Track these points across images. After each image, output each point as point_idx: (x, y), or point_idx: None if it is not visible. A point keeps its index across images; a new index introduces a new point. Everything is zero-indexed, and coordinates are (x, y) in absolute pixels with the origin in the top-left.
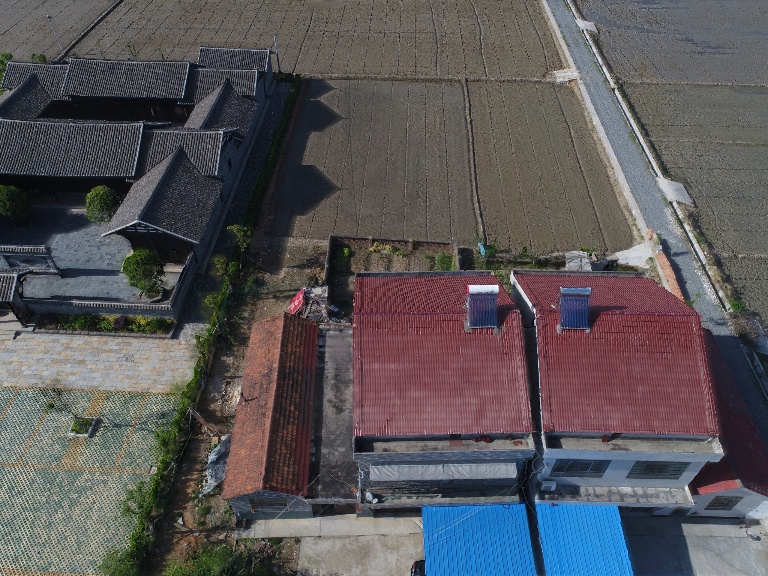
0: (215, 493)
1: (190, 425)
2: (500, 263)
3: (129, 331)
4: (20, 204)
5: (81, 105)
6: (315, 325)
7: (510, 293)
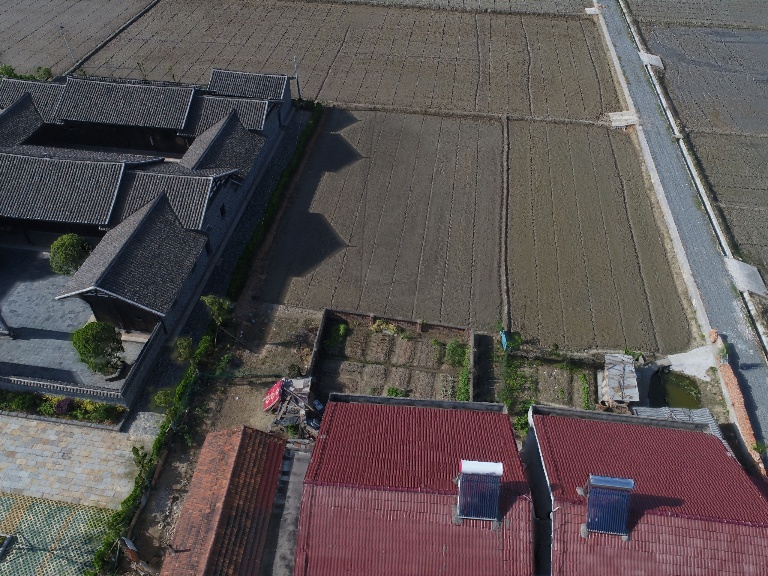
0: None
1: (117, 559)
2: (524, 359)
3: (73, 418)
4: None
5: (76, 129)
6: (281, 443)
7: None
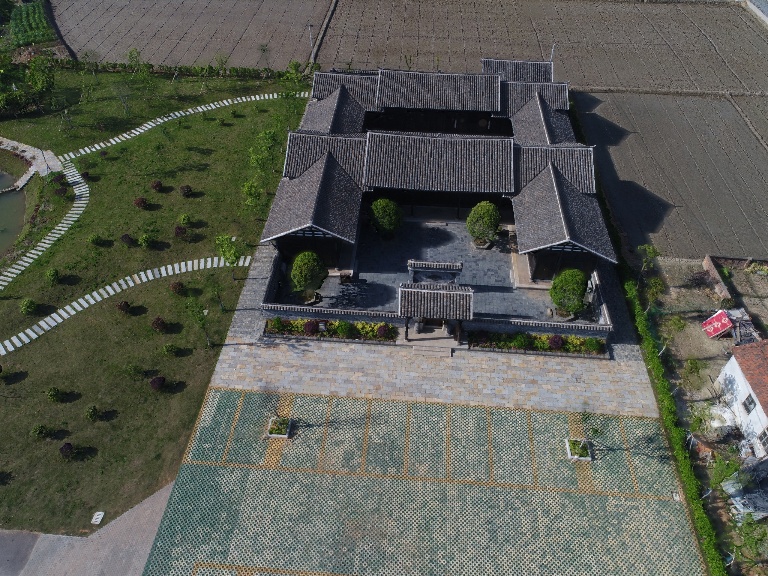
0: (759, 523)
1: (690, 451)
2: None
3: (565, 351)
4: (401, 218)
5: (385, 116)
6: None
7: None
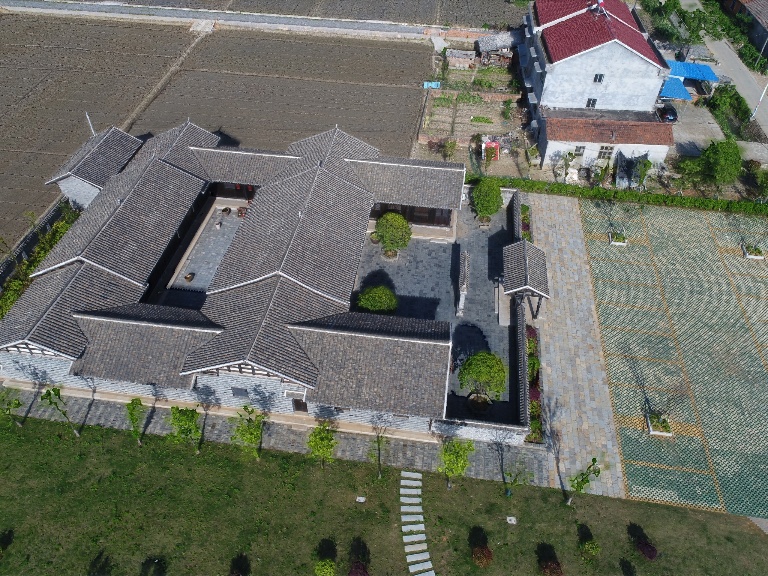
0: None
1: None
2: None
3: None
4: None
5: None
6: None
7: None
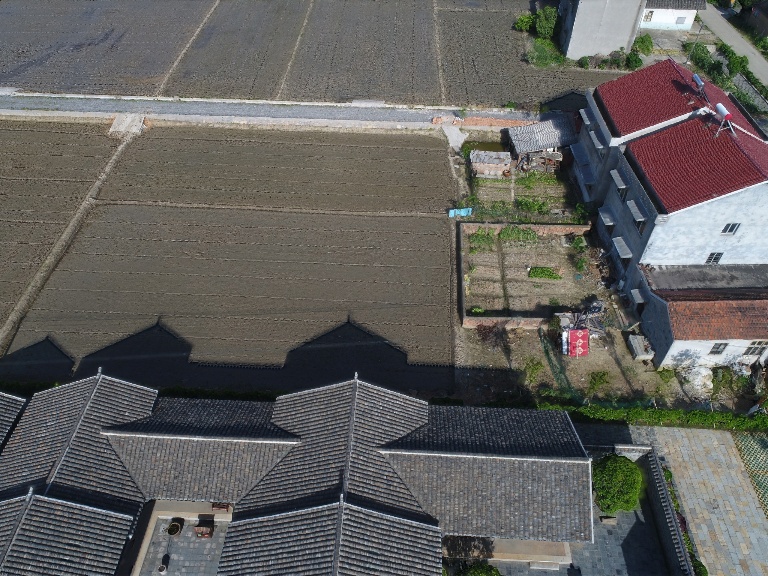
0: None
1: None
2: None
3: None
4: None
5: None
6: None
7: (522, 200)
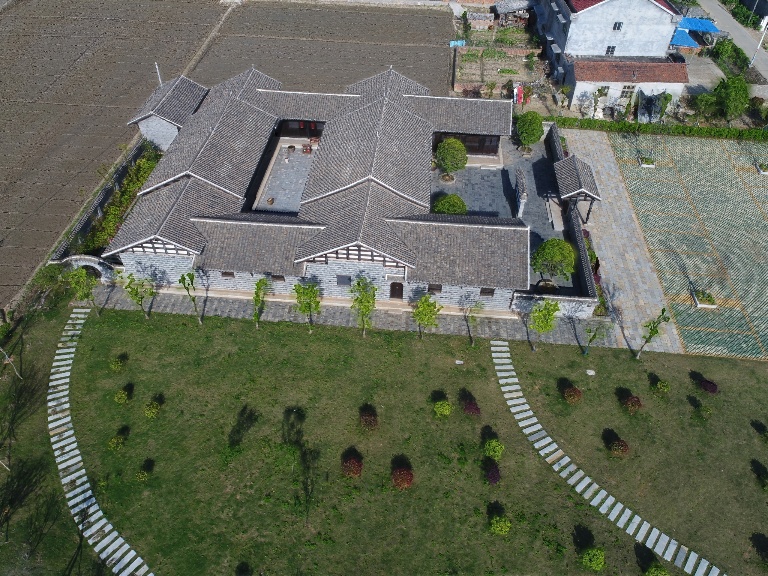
0: None
1: None
2: None
3: None
4: None
5: None
6: None
7: None
